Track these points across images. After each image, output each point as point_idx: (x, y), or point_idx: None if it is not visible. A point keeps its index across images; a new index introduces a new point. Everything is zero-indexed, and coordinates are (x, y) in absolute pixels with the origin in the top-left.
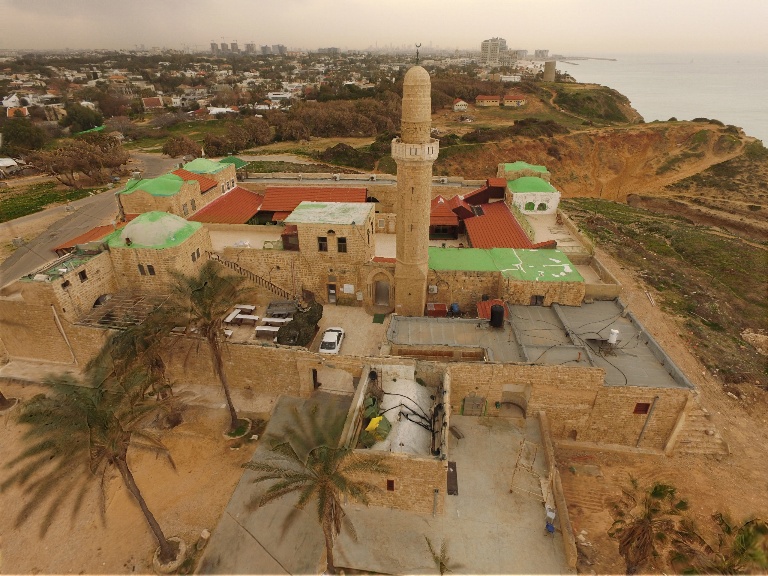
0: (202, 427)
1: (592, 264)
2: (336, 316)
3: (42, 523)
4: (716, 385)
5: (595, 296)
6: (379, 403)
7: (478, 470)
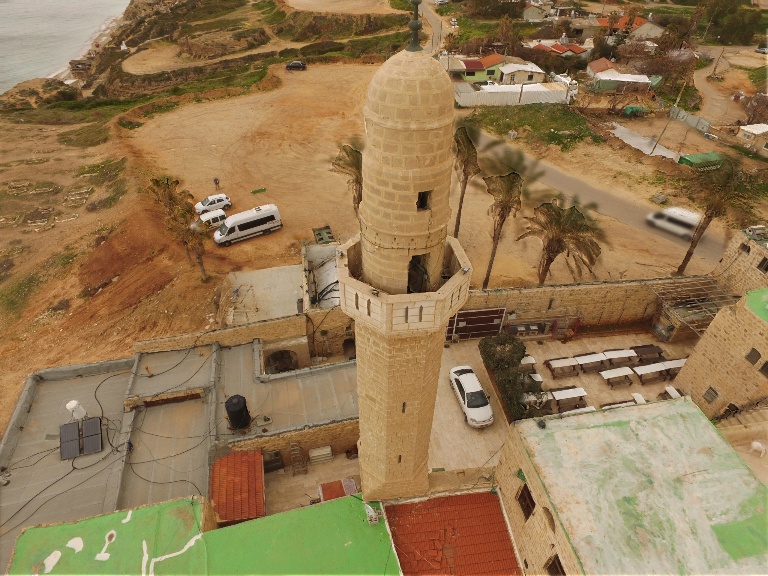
0: None
1: None
2: None
3: None
4: None
5: None
6: None
7: None
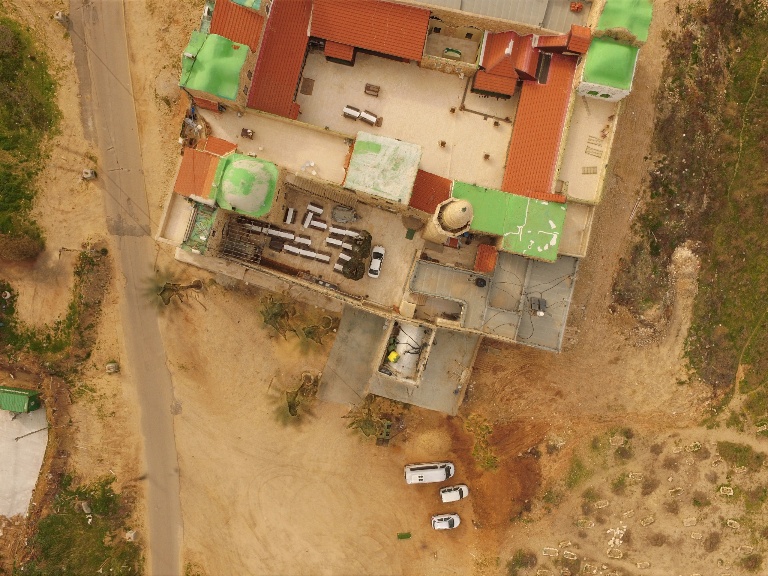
0: (307, 318)
1: (590, 210)
2: (381, 225)
3: (250, 353)
4: (608, 302)
5: (564, 255)
6: (397, 336)
7: (438, 359)
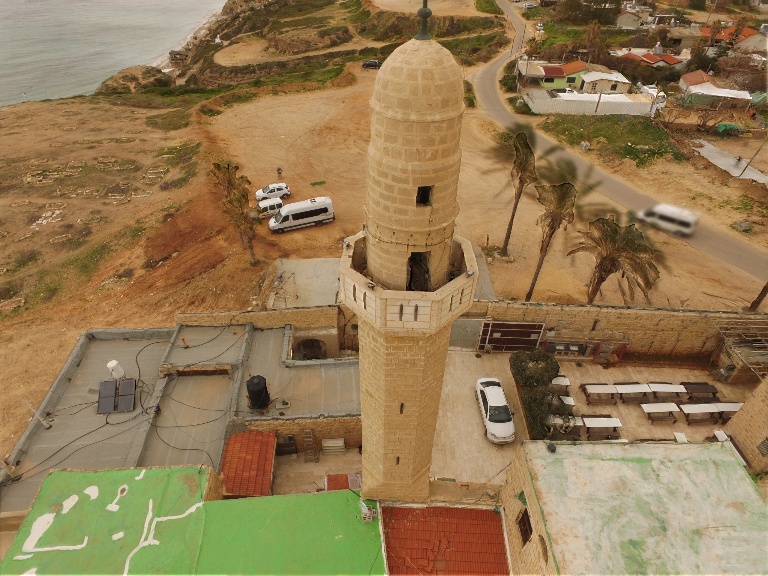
0: None
1: None
2: None
3: None
4: None
5: None
6: None
7: None
